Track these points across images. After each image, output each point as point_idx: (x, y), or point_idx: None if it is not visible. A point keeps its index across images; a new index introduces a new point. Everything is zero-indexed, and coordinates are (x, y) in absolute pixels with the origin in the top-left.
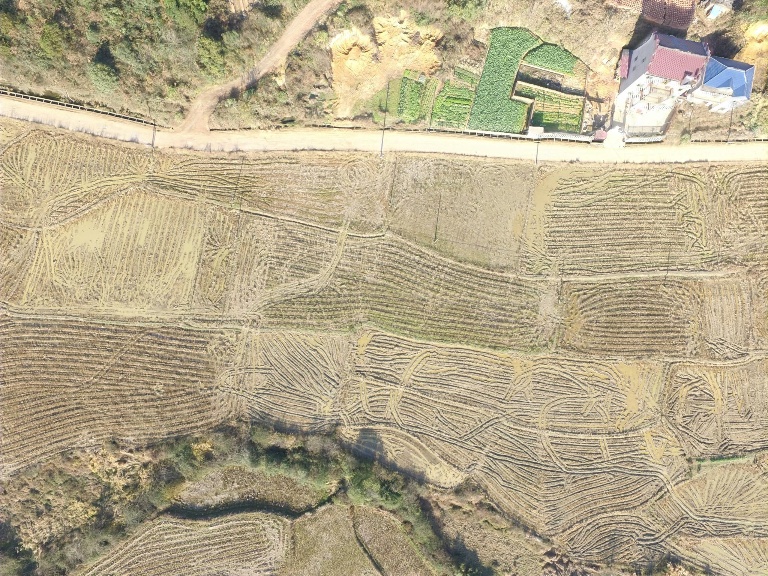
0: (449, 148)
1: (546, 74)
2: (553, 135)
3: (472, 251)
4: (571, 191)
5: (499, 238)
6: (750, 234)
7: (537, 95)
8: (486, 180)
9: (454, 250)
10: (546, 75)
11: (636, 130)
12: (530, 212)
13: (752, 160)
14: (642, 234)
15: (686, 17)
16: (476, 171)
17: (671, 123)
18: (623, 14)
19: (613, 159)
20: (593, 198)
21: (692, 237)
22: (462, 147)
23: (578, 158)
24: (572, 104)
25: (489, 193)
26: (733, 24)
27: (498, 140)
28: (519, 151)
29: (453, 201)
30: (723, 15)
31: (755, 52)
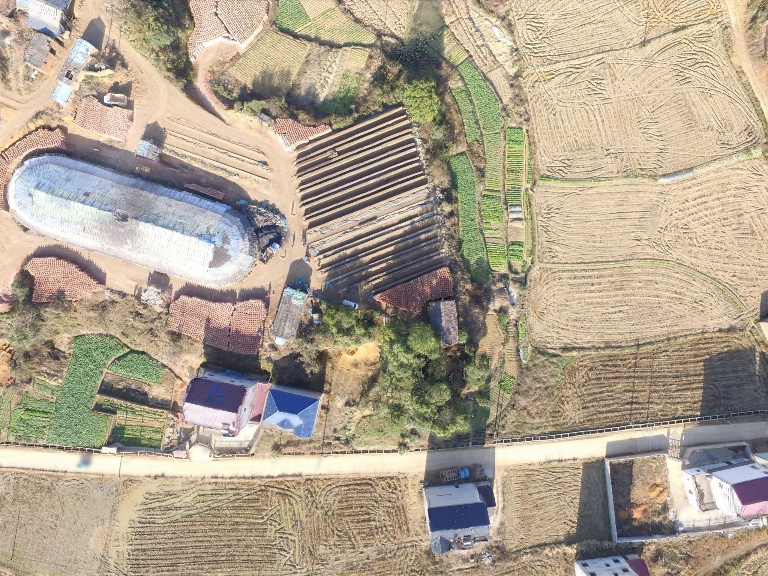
0: (28, 462)
1: (132, 383)
2: (132, 452)
3: (51, 570)
4: (157, 506)
5: (79, 556)
6: (347, 551)
7: (118, 408)
8: (68, 495)
9: (32, 569)
10: (132, 384)
11: (223, 445)
12: (113, 529)
13: (349, 473)
14: (231, 552)
15: (251, 345)
16: (58, 485)
17: (254, 442)
18: (186, 341)
19: (201, 473)
20: (180, 513)
21: (285, 554)
22: (41, 461)
23: (164, 472)
24: (156, 417)
25: (71, 508)
26: (303, 351)
27: (79, 454)
28: (101, 465)
29: (32, 517)
30: (289, 343)
31: (349, 363)
